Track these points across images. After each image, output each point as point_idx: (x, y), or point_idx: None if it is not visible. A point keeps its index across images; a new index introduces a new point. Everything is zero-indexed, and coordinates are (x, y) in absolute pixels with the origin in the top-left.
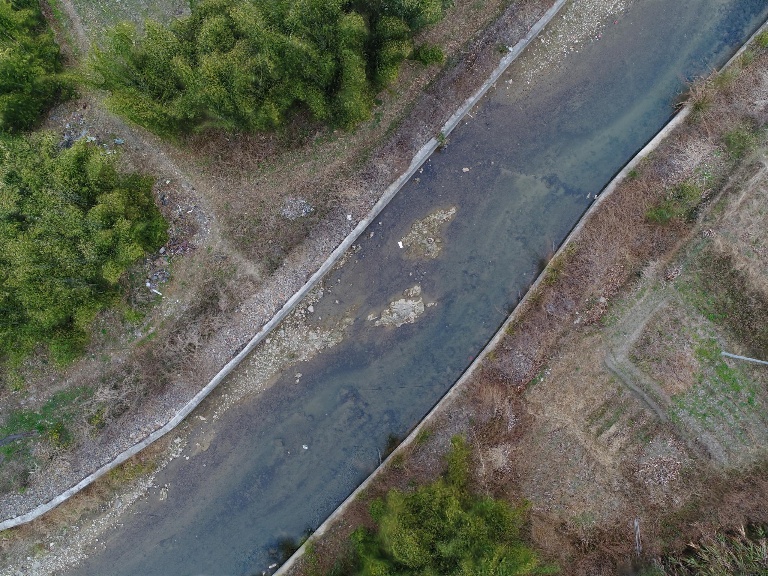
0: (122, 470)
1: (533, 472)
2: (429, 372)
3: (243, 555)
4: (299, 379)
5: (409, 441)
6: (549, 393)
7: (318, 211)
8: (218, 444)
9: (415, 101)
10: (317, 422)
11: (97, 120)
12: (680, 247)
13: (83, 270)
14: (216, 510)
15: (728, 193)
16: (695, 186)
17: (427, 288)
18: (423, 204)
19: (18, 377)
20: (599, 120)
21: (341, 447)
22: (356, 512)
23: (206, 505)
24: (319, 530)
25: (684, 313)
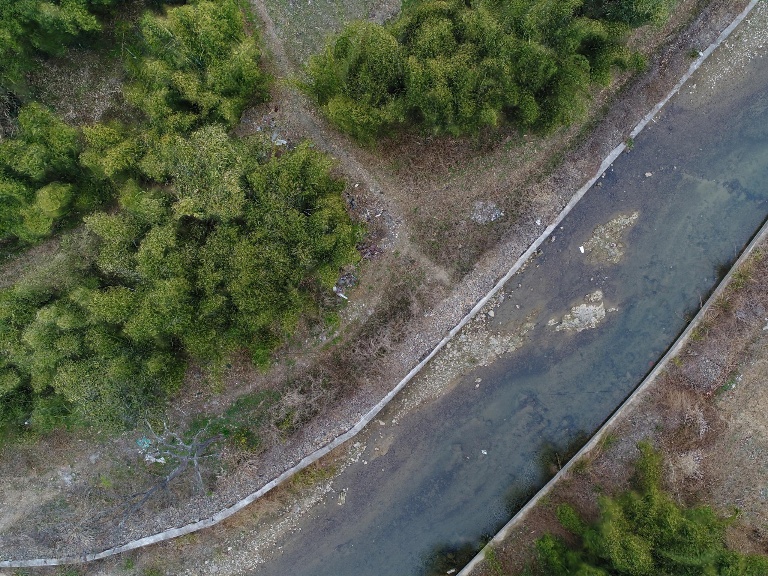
0: (304, 474)
1: (724, 479)
2: (608, 377)
3: (420, 560)
4: (479, 384)
5: (591, 447)
6: (740, 400)
7: (510, 216)
8: (396, 449)
9: (606, 106)
10: (495, 427)
11: (288, 123)
12: None
13: (292, 274)
14: (393, 515)
15: None
16: None
17: (608, 293)
18: (604, 209)
19: (201, 381)
20: None
21: (519, 452)
22: (540, 518)
23: (383, 510)
24: (499, 536)
25: None
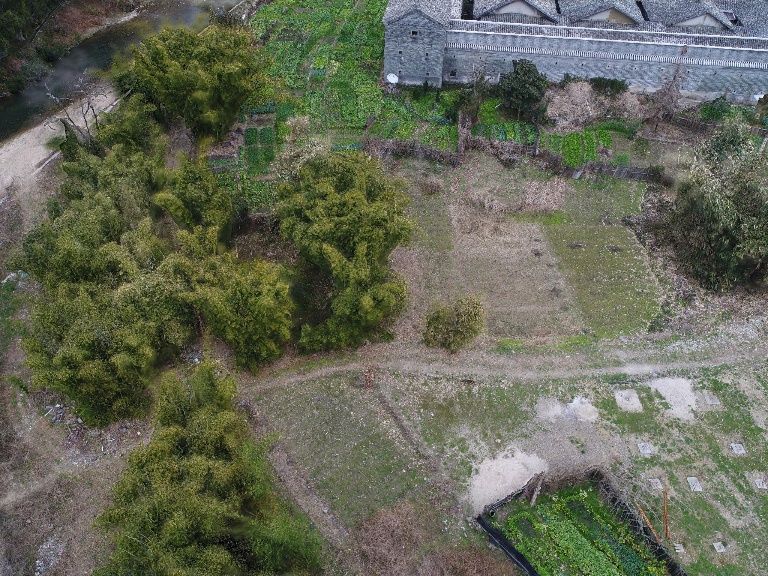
0: None
1: None
2: None
3: None
4: None
5: None
6: None
7: None
8: None
9: None
10: None
11: None
12: None
13: None
14: None
15: None
16: None
17: None
18: None
19: None
20: None
21: None
22: None
23: None
24: None
25: None
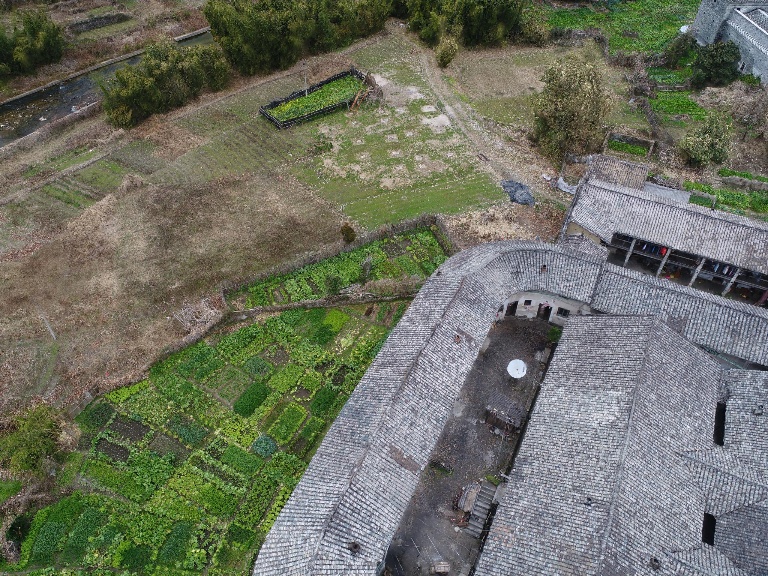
0: None
1: None
2: None
3: None
4: None
5: None
6: None
7: None
8: None
9: None
10: None
11: None
12: None
13: None
14: None
15: None
16: None
17: None
18: None
19: None
20: None
21: None
22: None
23: None
24: None
25: (186, 1)
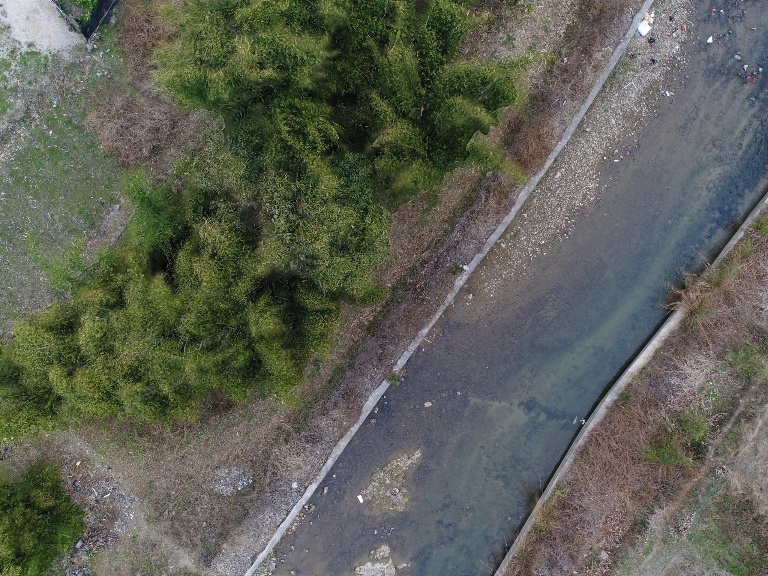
0: None
1: None
2: None
3: None
4: None
5: None
6: None
7: (256, 485)
8: None
9: (359, 342)
10: None
11: None
12: (690, 489)
13: None
14: None
15: (741, 420)
16: (700, 410)
17: (396, 546)
18: (382, 448)
19: None
20: (579, 329)
21: None
22: None
23: None
24: None
25: (703, 568)
